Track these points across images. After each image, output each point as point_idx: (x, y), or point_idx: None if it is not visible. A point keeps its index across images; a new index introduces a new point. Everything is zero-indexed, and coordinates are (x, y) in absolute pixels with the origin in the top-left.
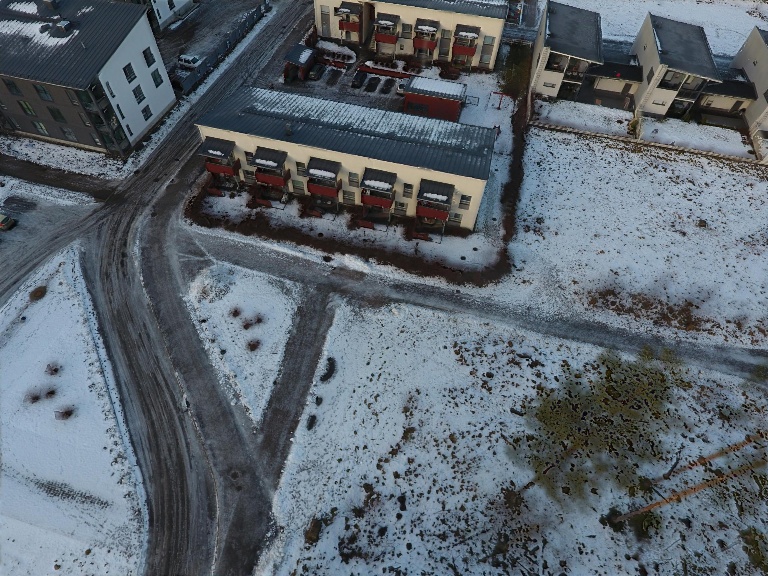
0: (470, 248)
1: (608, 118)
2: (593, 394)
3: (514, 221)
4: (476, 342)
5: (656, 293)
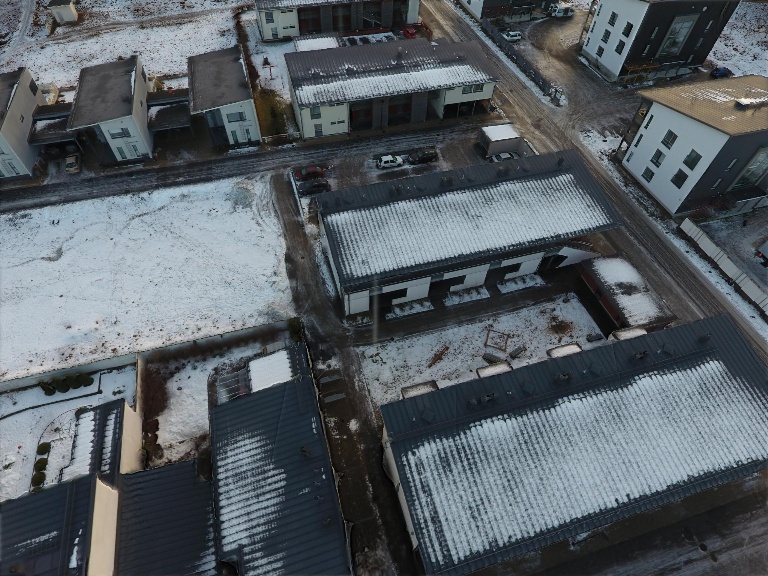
0: None
1: None
2: (190, 1)
3: None
4: None
5: None
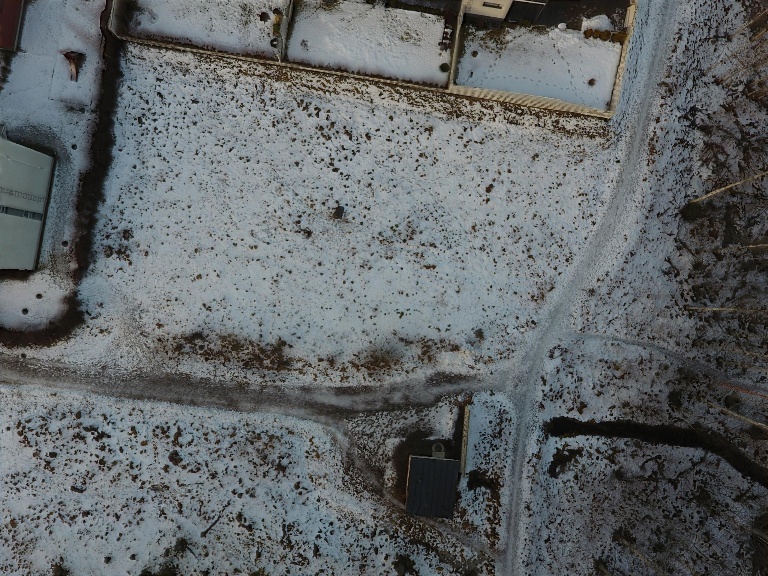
0: (32, 296)
1: (249, 8)
2: (155, 462)
3: (93, 241)
4: (41, 418)
5: (248, 332)
